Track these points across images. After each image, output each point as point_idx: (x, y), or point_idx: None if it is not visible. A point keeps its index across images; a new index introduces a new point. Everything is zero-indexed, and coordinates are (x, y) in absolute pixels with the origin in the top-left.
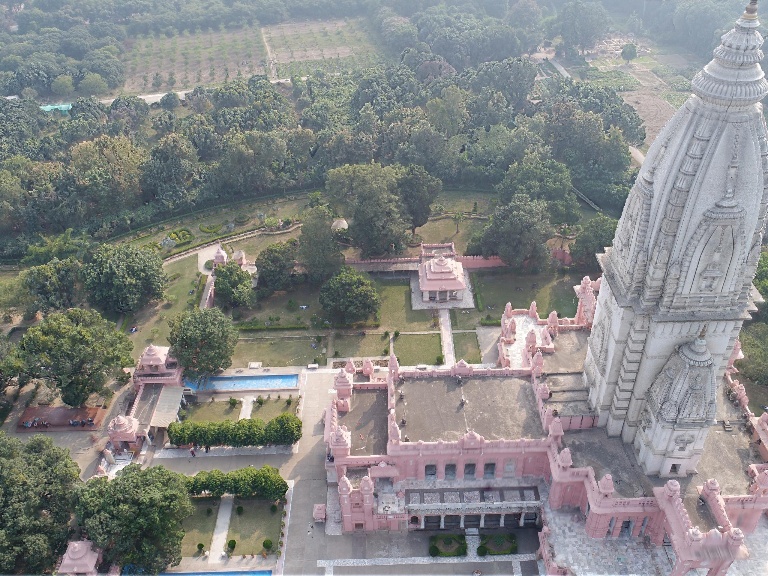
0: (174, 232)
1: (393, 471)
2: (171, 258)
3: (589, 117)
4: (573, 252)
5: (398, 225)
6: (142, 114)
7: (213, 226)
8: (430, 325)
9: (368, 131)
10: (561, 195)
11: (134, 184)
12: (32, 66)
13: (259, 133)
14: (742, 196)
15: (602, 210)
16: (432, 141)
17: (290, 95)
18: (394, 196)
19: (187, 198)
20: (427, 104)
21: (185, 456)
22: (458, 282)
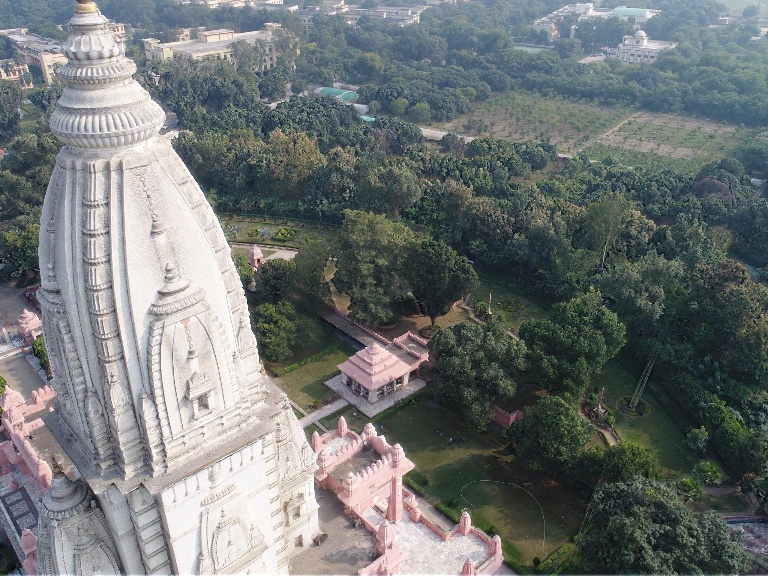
0: (287, 229)
1: (13, 456)
2: (258, 245)
3: (741, 290)
4: (511, 425)
5: (372, 292)
6: (409, 142)
7: (316, 238)
8: (311, 404)
9: (517, 212)
10: (575, 356)
11: (291, 179)
12: (392, 86)
13: (404, 172)
14: (61, 282)
15: (680, 422)
16: (550, 244)
17: (561, 171)
18: (382, 260)
19: (319, 207)
20: (589, 205)
21: (35, 368)
22: (370, 379)
